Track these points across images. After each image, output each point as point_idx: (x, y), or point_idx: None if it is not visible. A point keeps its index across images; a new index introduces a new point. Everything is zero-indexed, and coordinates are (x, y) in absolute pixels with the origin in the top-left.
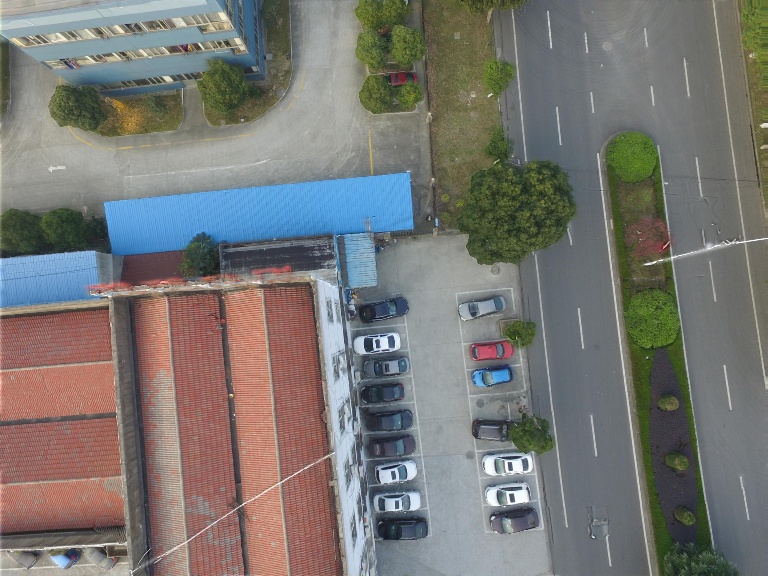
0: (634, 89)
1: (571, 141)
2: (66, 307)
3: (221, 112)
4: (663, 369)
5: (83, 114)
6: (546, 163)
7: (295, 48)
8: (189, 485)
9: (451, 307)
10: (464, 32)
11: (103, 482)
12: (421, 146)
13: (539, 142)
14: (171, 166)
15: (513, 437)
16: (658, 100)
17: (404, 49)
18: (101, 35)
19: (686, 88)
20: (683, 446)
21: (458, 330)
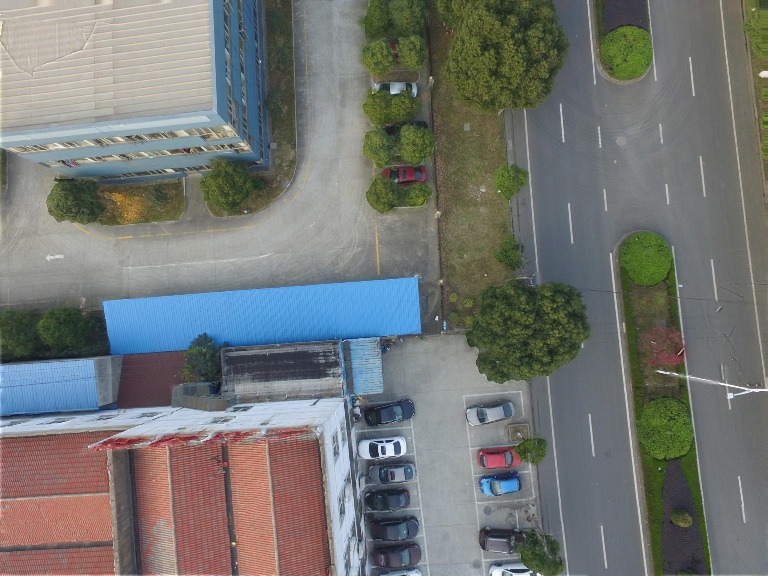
0: (648, 186)
1: (583, 239)
2: None
3: None
4: (676, 482)
5: (82, 211)
6: (560, 288)
7: (300, 137)
8: None
9: (459, 410)
10: (474, 123)
11: None
12: (429, 242)
13: (550, 240)
14: (172, 258)
15: (522, 557)
16: (673, 199)
17: (413, 151)
18: (100, 144)
19: (702, 188)
20: (696, 562)
21: (466, 434)
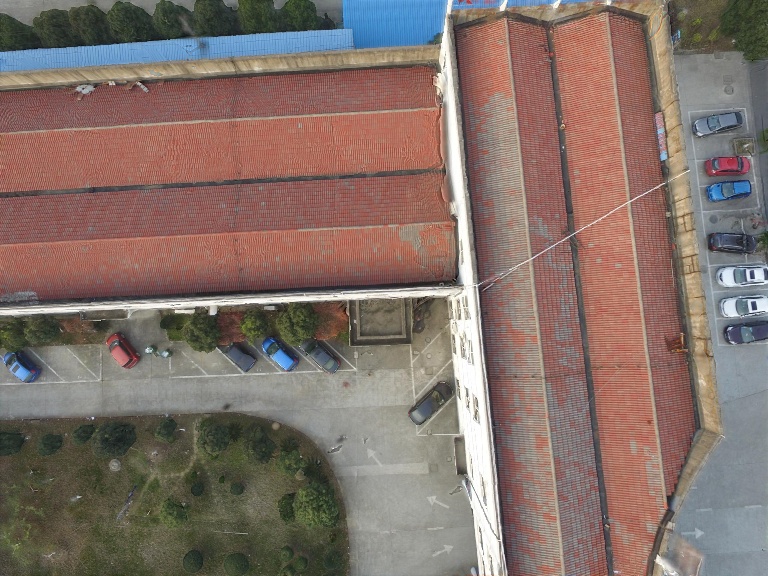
0: None
1: None
2: (348, 64)
3: None
4: None
5: None
6: None
7: None
8: (531, 205)
9: None
10: None
11: (400, 230)
12: None
13: None
14: None
15: None
16: None
17: None
18: None
19: None
20: None
21: (691, 147)
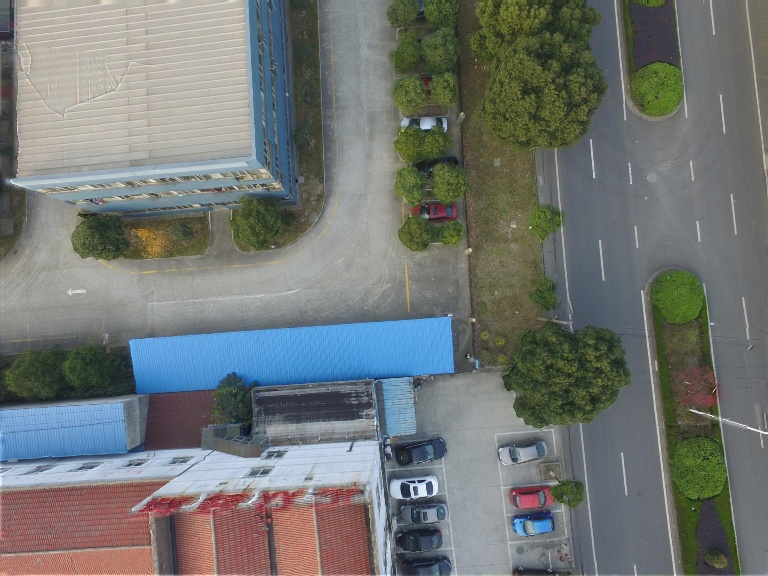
0: (679, 223)
1: (614, 277)
2: None
3: None
4: (710, 522)
5: (108, 248)
6: (601, 335)
7: (328, 170)
8: None
9: (490, 448)
10: (504, 159)
11: None
12: (459, 278)
13: (581, 277)
14: (198, 293)
15: None
16: (704, 236)
17: (447, 190)
18: (132, 185)
19: (733, 226)
20: None
21: (497, 473)
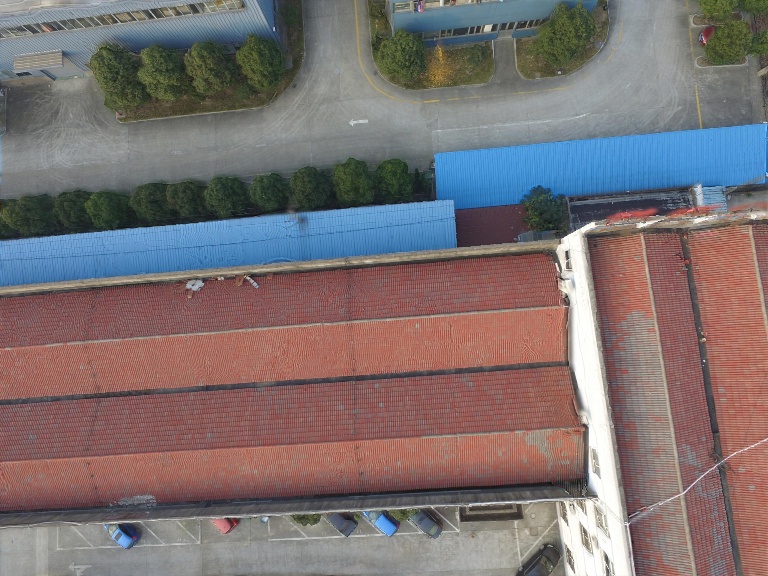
0: None
1: None
2: (460, 254)
3: (535, 64)
4: None
5: (415, 61)
6: None
7: None
8: (679, 433)
9: None
10: None
11: (527, 435)
12: (752, 100)
13: None
14: (483, 120)
15: None
16: None
17: None
18: None
19: None
20: None
21: None
